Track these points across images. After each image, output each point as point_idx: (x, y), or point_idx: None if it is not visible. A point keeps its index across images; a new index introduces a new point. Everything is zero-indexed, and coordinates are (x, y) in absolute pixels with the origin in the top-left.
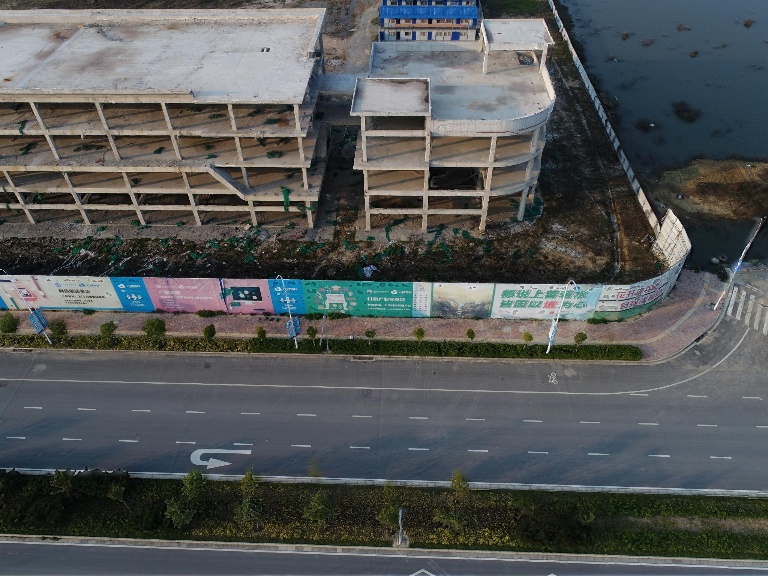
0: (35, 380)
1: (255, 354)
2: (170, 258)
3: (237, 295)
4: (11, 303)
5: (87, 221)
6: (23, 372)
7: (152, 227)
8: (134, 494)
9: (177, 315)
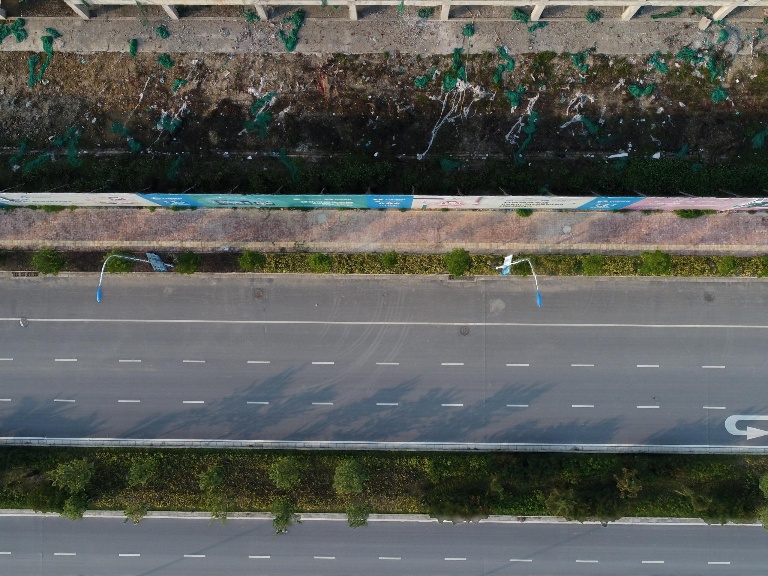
0: (501, 325)
1: (766, 278)
2: (598, 96)
3: (759, 204)
4: (419, 206)
5: (445, 17)
6: (480, 313)
7: (549, 25)
8: (682, 473)
9: (648, 215)
